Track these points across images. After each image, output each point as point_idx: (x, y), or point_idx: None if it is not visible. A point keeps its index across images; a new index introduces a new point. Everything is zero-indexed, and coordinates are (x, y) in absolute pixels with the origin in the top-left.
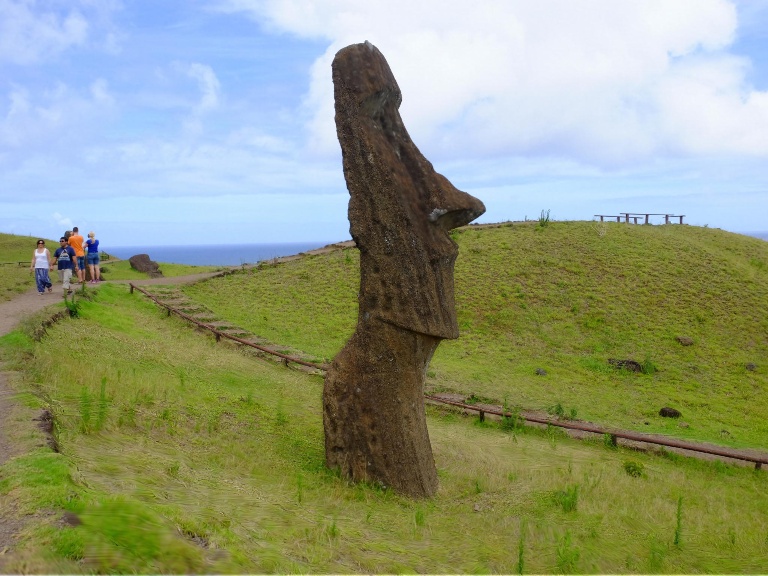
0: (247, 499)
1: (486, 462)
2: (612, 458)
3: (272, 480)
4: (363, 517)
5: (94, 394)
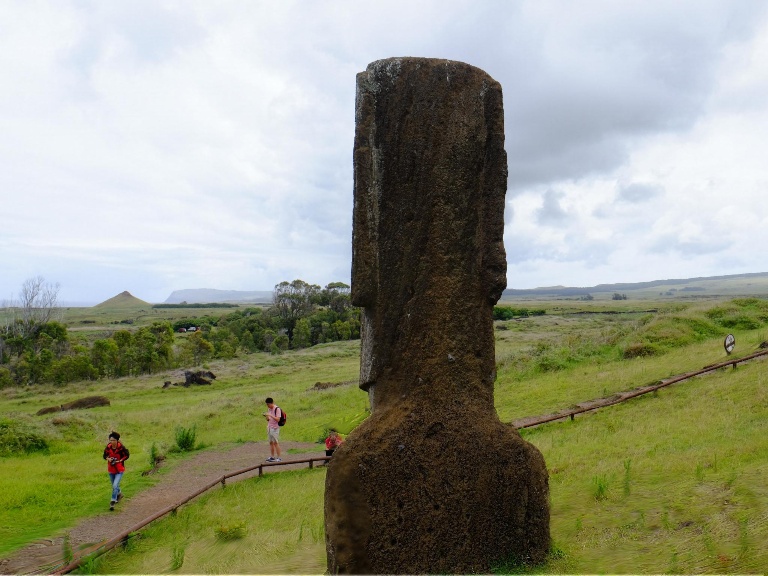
0: (766, 488)
1: (296, 567)
2: (197, 543)
3: (614, 569)
4: (609, 541)
5: (763, 559)
